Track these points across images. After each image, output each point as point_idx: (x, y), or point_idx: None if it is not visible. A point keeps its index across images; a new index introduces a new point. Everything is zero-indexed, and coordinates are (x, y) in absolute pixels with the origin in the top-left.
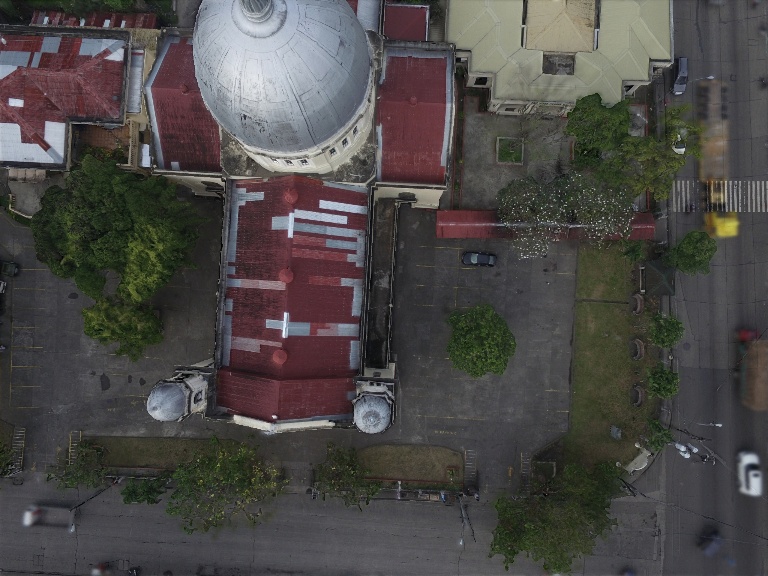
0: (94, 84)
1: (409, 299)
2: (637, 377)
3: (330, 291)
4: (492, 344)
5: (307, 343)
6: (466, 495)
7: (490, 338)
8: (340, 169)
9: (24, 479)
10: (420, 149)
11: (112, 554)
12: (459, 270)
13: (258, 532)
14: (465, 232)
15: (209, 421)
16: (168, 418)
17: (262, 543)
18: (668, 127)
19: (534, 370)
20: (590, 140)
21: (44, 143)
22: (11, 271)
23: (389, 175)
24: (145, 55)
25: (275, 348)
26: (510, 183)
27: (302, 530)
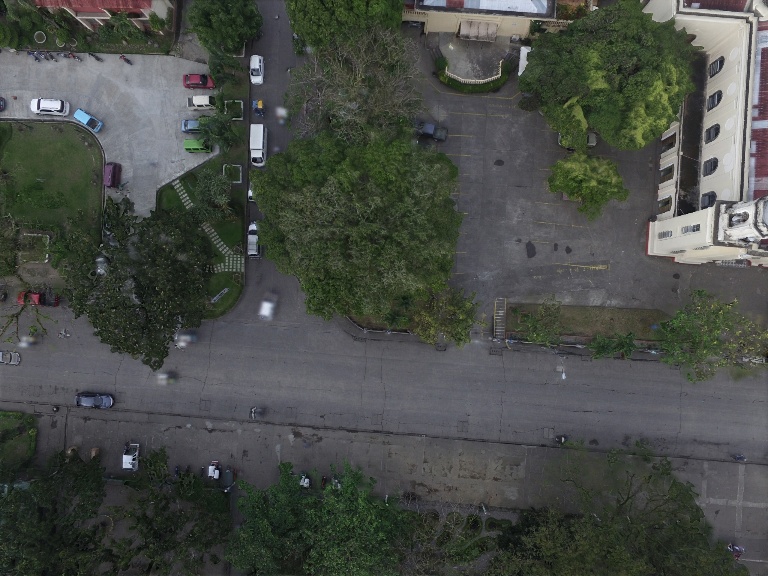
0: None
1: None
2: None
3: None
4: None
5: None
6: None
7: None
8: None
9: (447, 345)
10: None
11: (537, 422)
12: None
13: (685, 403)
14: None
15: (635, 291)
16: None
17: (689, 414)
18: None
19: None
20: None
21: None
22: (441, 135)
23: None
24: None
25: None
26: None
27: (729, 402)
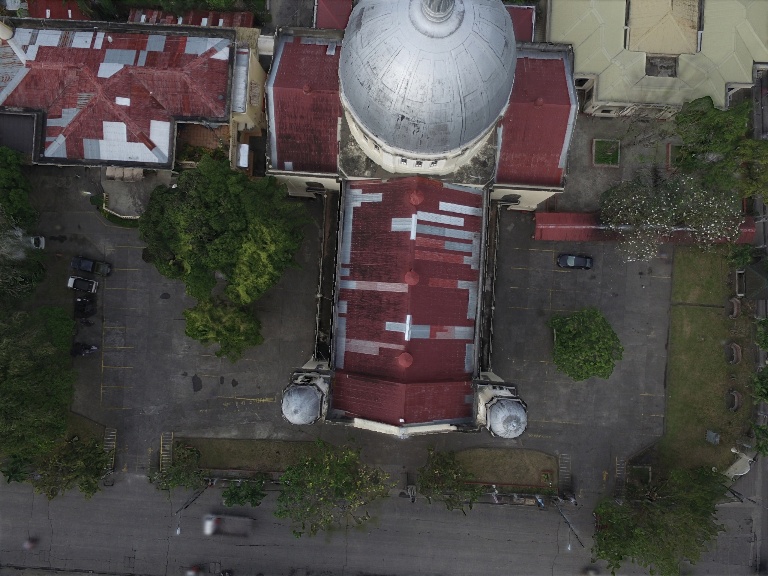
0: (200, 83)
1: (503, 302)
2: (733, 382)
3: (448, 294)
4: (602, 348)
5: (427, 346)
6: (563, 499)
7: (601, 342)
8: (460, 171)
9: (115, 480)
10: (539, 151)
11: (204, 556)
12: (554, 273)
13: (351, 535)
14: (564, 234)
15: None
16: (305, 421)
17: (355, 546)
18: (765, 130)
19: (629, 374)
20: (701, 143)
21: (149, 142)
22: (103, 271)
23: (505, 177)
24: (250, 54)
25: (397, 351)
26: (616, 186)
27: (395, 533)
